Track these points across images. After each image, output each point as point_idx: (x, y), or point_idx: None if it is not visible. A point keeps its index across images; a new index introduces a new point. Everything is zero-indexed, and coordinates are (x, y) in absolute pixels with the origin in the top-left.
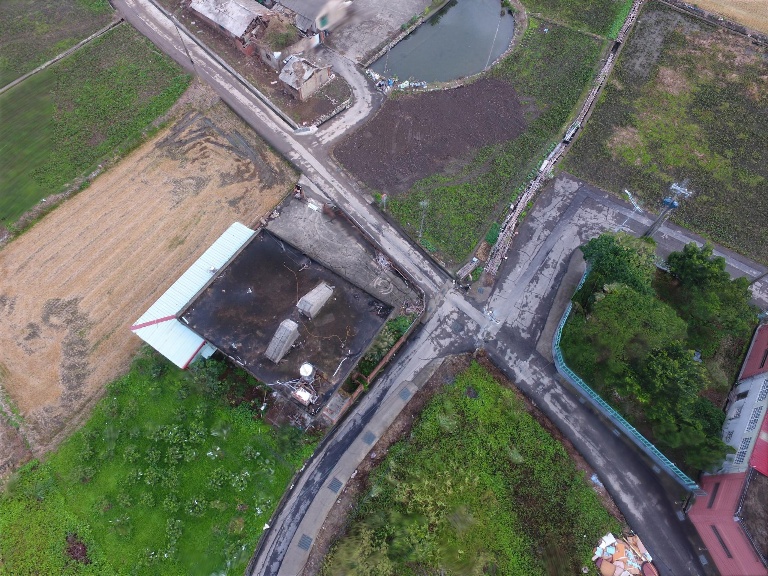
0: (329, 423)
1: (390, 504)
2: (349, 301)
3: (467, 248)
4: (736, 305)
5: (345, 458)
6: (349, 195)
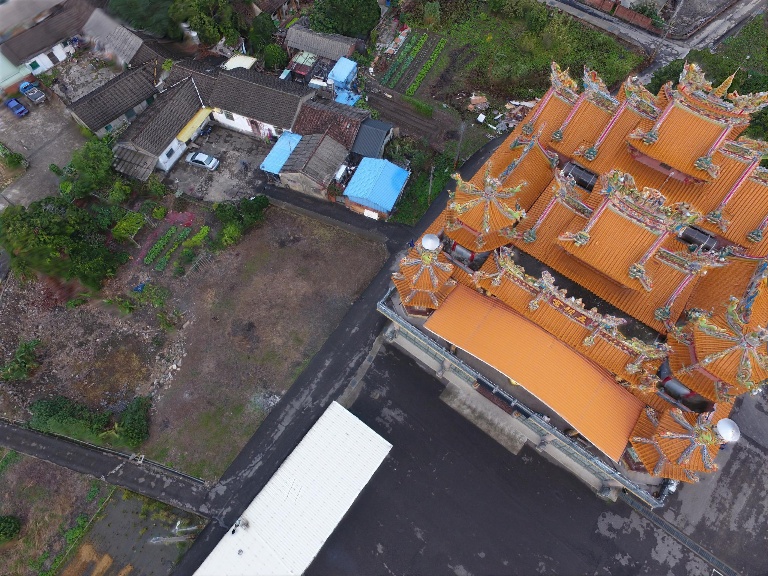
0: (585, 1)
1: (548, 22)
2: None
3: (735, 60)
4: (756, 137)
5: (568, 6)
6: (753, 5)
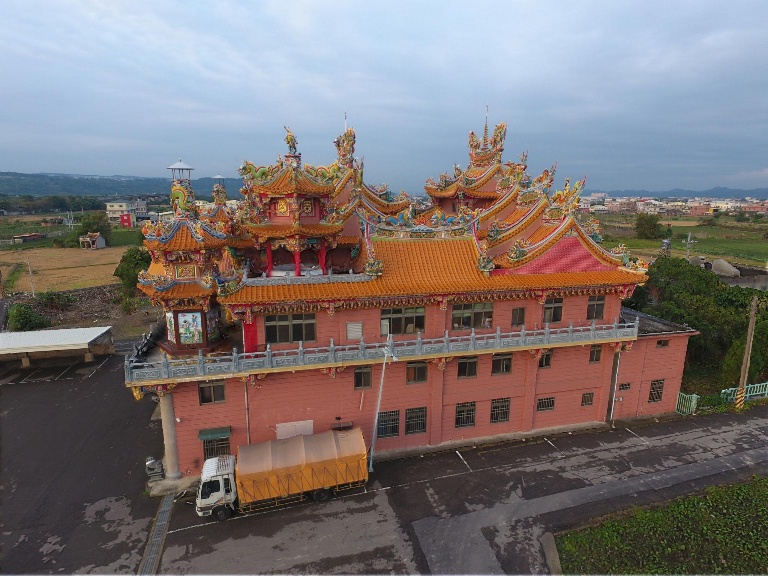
0: None
1: None
2: (725, 278)
3: None
4: None
5: None
6: None
